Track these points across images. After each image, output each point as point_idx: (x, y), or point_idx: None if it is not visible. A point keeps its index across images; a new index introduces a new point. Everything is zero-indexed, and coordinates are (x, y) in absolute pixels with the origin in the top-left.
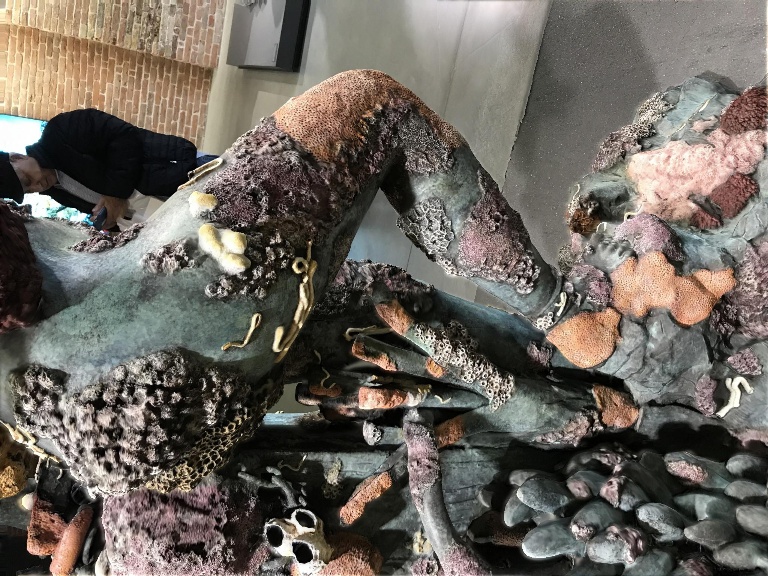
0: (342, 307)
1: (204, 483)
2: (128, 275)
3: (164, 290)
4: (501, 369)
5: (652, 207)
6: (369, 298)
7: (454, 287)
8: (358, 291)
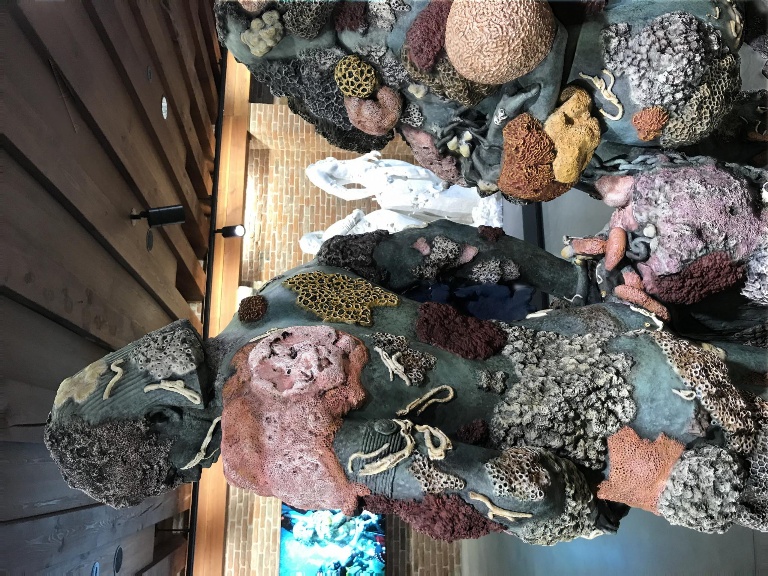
0: (747, 99)
1: (704, 165)
2: None
3: None
4: None
5: None
6: (767, 77)
7: None
8: (753, 93)
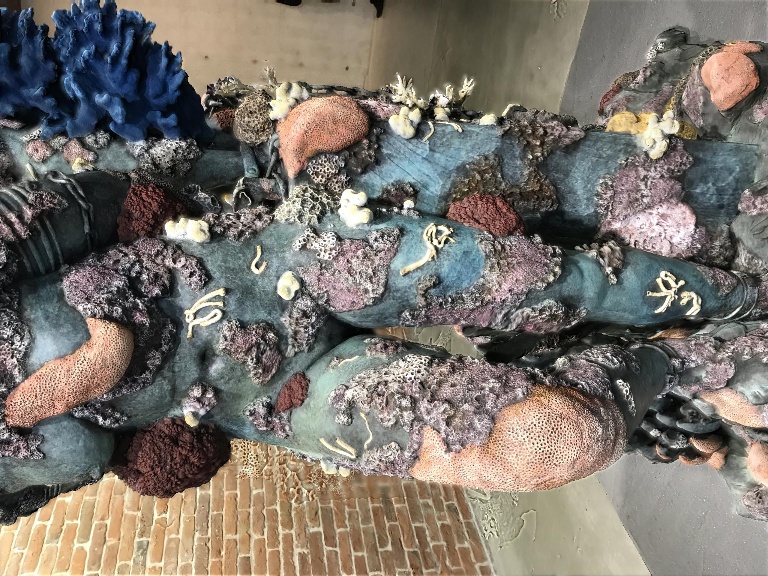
0: None
1: None
2: None
3: None
4: (587, 333)
5: None
6: None
7: None
8: None
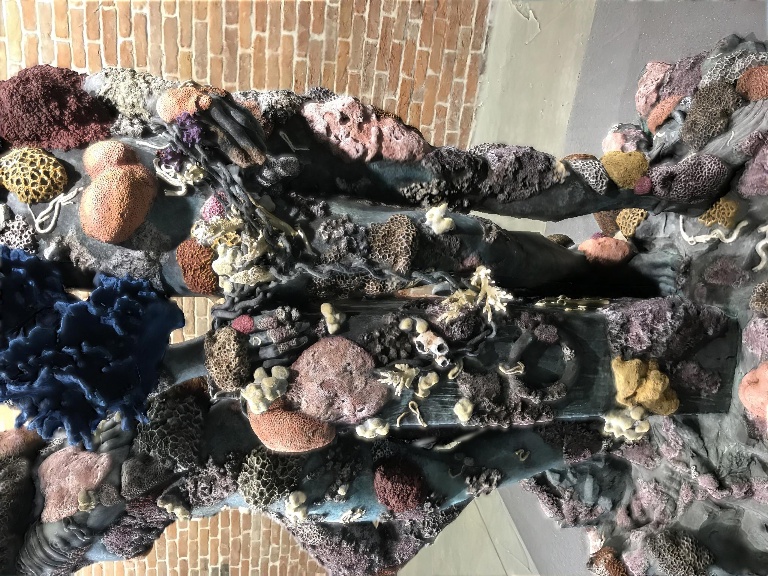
0: None
1: None
2: None
3: None
4: None
5: (597, 539)
6: None
7: None
8: None
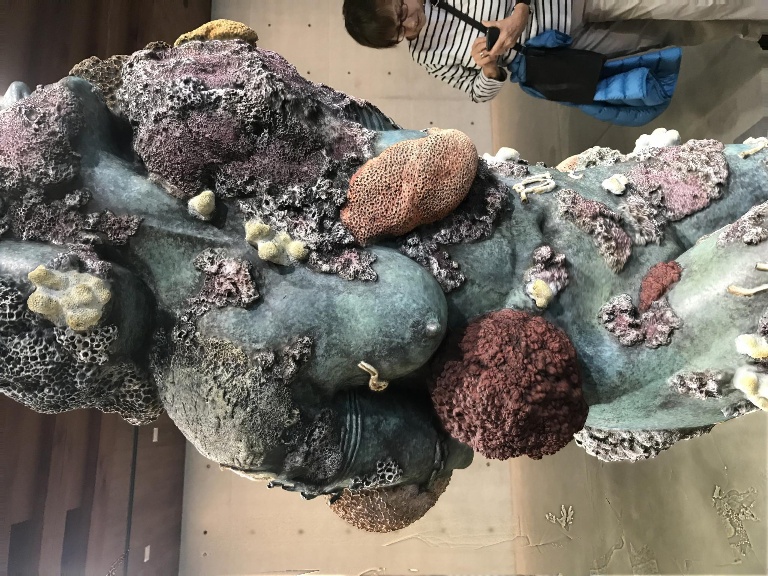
0: None
1: None
2: (655, 389)
3: (684, 405)
4: None
5: None
6: None
7: None
8: None
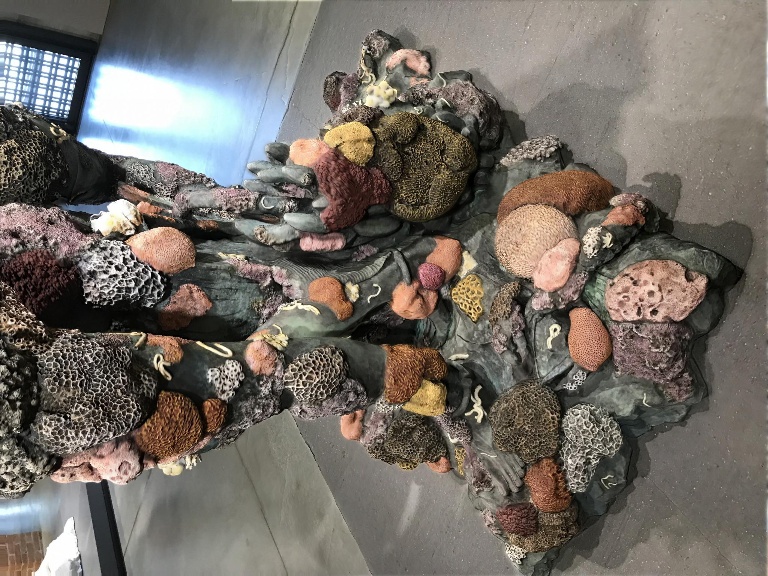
0: None
1: None
2: None
3: None
4: None
5: None
6: None
7: (341, 566)
8: None
